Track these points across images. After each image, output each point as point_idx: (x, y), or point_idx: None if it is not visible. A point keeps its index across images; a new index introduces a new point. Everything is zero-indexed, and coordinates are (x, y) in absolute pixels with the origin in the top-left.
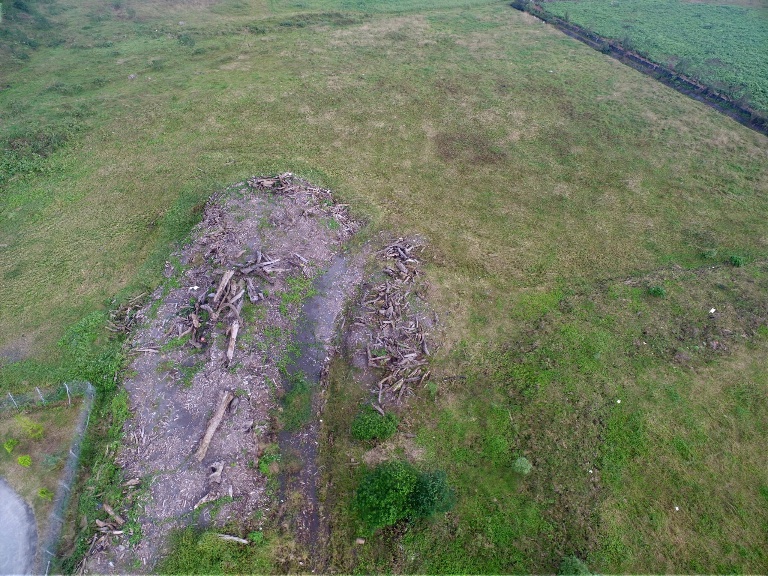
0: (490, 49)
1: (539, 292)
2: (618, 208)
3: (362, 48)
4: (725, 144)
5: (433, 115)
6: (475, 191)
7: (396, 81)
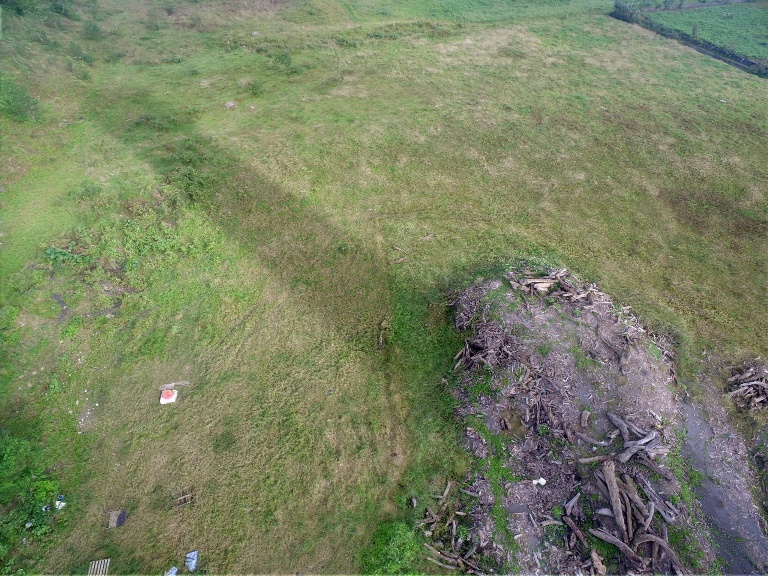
0: (631, 71)
1: None
2: None
3: (482, 68)
4: None
5: (633, 162)
6: None
7: (553, 113)
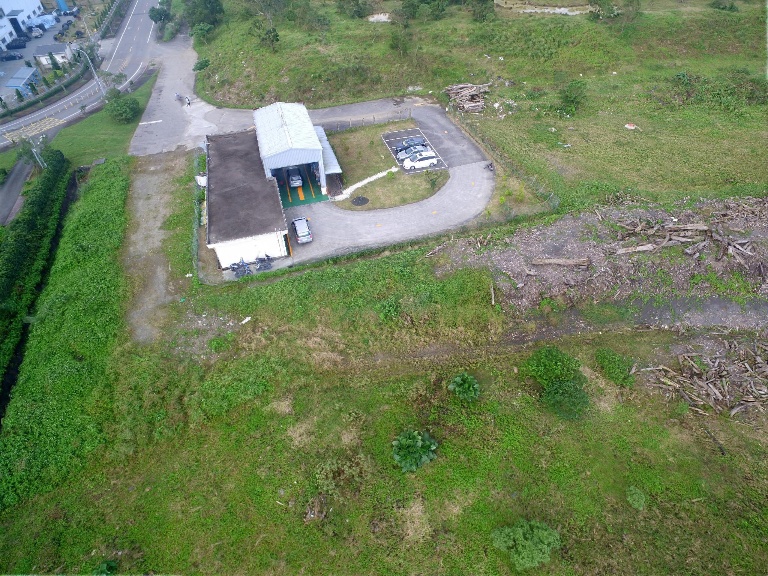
0: None
1: None
2: None
3: None
4: None
5: None
6: None
7: None
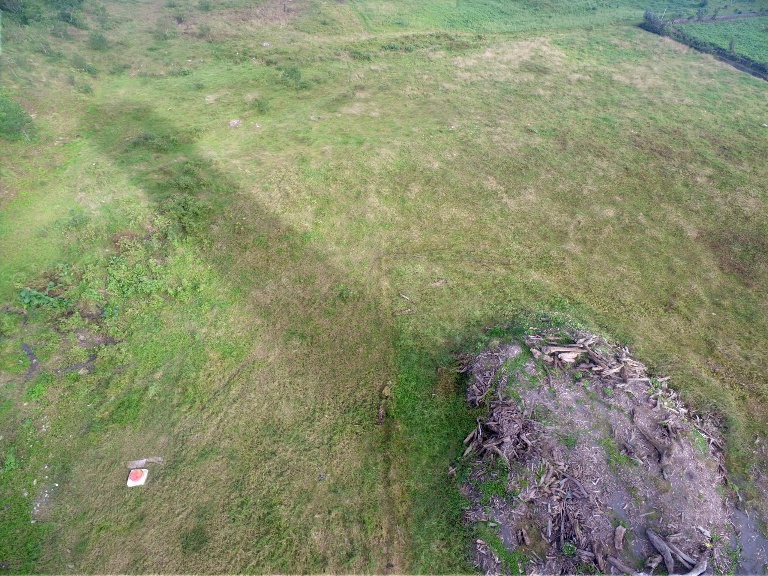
0: (663, 89)
1: None
2: None
3: (503, 84)
4: None
5: (668, 196)
6: None
7: (579, 137)
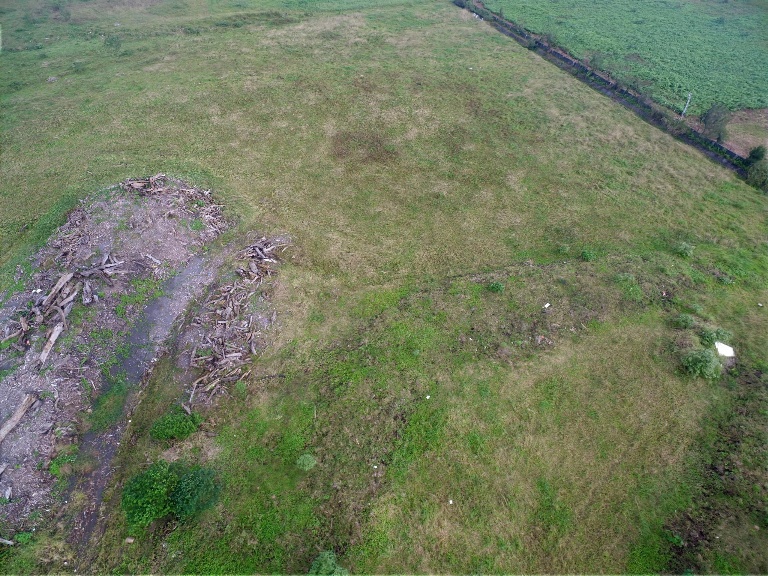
0: (418, 47)
1: (385, 290)
2: (492, 205)
3: (291, 47)
4: (617, 139)
5: (339, 114)
6: (356, 190)
7: (314, 80)
